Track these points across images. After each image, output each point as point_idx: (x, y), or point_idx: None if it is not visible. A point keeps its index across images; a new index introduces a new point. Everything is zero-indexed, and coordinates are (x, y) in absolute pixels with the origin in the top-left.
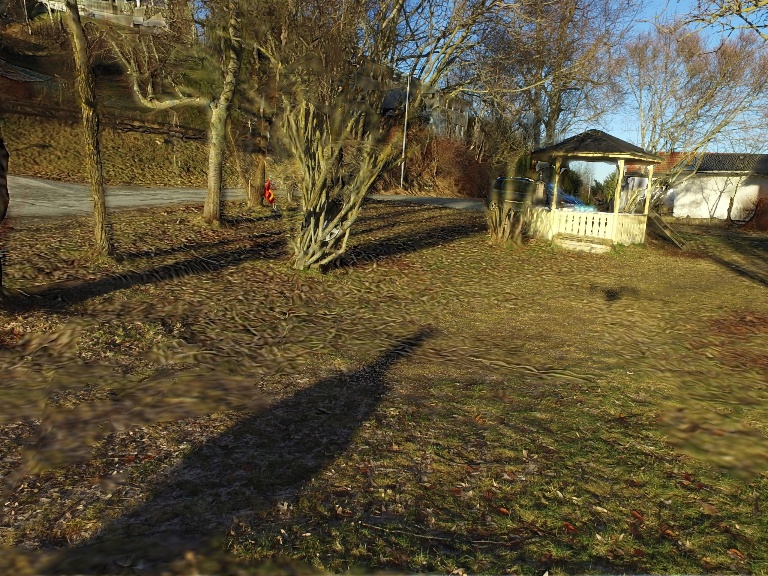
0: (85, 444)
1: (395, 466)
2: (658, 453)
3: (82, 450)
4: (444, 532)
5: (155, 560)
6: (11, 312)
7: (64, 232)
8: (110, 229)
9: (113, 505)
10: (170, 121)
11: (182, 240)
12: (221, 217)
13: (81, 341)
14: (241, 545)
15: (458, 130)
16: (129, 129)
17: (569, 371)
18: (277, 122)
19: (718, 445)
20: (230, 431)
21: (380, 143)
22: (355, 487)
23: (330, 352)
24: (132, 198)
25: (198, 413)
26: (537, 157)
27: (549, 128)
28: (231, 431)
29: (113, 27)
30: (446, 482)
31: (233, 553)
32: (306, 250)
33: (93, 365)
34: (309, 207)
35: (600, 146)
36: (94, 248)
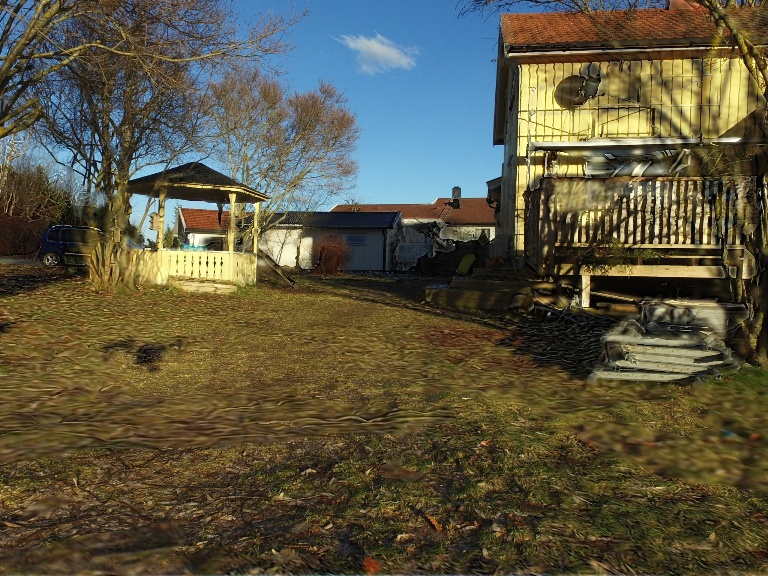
0: None
1: None
2: (681, 493)
3: None
4: None
5: None
6: None
7: None
8: None
9: None
10: None
11: None
12: None
13: None
14: None
15: None
16: None
17: None
18: None
19: (692, 460)
20: None
21: None
22: None
23: None
24: None
25: None
26: (132, 188)
27: (121, 168)
28: None
29: None
30: None
31: None
32: None
33: None
34: None
35: (207, 178)
36: None
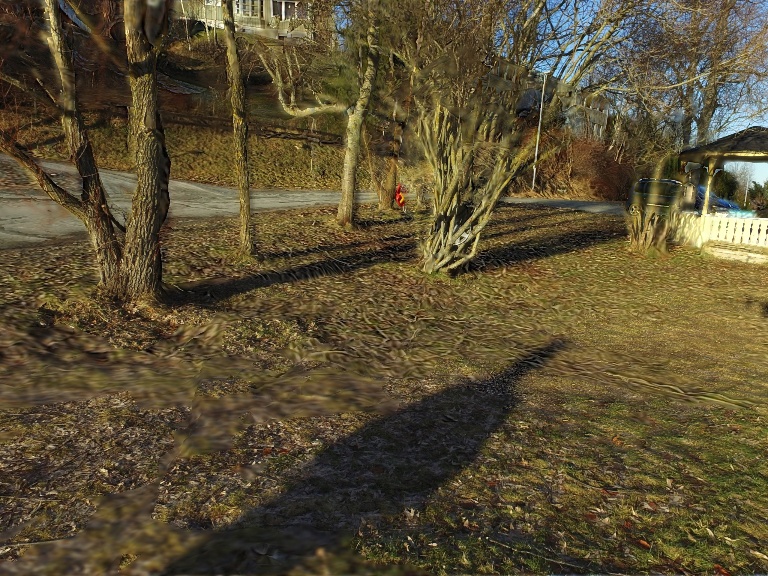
0: (228, 433)
1: (524, 483)
2: None
3: (226, 439)
4: (577, 559)
5: (288, 552)
6: (168, 305)
7: (213, 232)
8: (253, 230)
9: (252, 494)
10: (308, 127)
11: (317, 241)
12: (353, 219)
13: (226, 335)
14: (369, 547)
15: (596, 129)
16: (272, 135)
17: (721, 395)
18: (409, 126)
19: None
20: (359, 432)
21: (512, 144)
22: (482, 500)
23: (458, 359)
24: (272, 200)
25: (330, 411)
26: (687, 157)
27: (701, 125)
28: (360, 432)
29: (261, 40)
30: (579, 505)
31: (361, 554)
32: (435, 254)
33: (236, 358)
34: (440, 211)
35: (763, 145)
36: (239, 248)
